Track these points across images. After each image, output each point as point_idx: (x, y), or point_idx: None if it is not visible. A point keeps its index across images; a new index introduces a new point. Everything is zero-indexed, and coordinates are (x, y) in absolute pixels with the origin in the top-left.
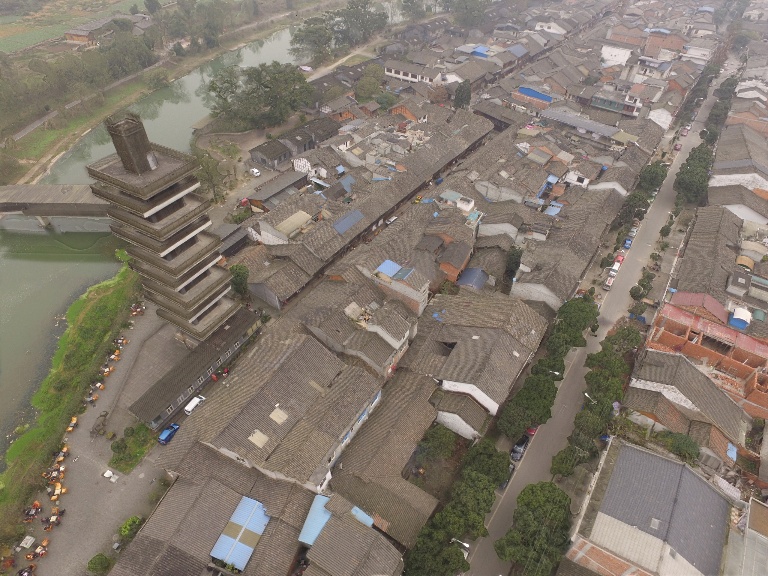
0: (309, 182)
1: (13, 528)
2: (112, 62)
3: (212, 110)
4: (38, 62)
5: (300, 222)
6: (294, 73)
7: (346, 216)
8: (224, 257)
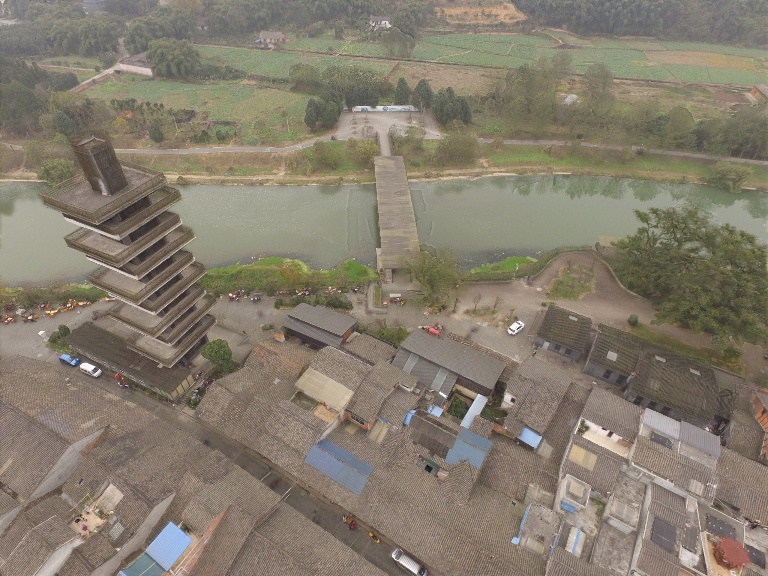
0: (502, 400)
1: (24, 299)
2: (701, 131)
3: (629, 238)
4: (608, 94)
5: (324, 396)
6: (761, 287)
7: (344, 461)
8: (280, 335)
